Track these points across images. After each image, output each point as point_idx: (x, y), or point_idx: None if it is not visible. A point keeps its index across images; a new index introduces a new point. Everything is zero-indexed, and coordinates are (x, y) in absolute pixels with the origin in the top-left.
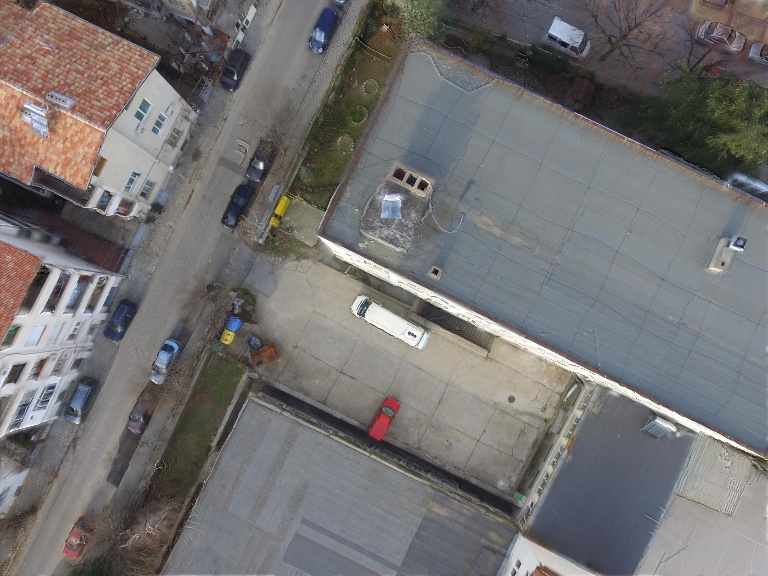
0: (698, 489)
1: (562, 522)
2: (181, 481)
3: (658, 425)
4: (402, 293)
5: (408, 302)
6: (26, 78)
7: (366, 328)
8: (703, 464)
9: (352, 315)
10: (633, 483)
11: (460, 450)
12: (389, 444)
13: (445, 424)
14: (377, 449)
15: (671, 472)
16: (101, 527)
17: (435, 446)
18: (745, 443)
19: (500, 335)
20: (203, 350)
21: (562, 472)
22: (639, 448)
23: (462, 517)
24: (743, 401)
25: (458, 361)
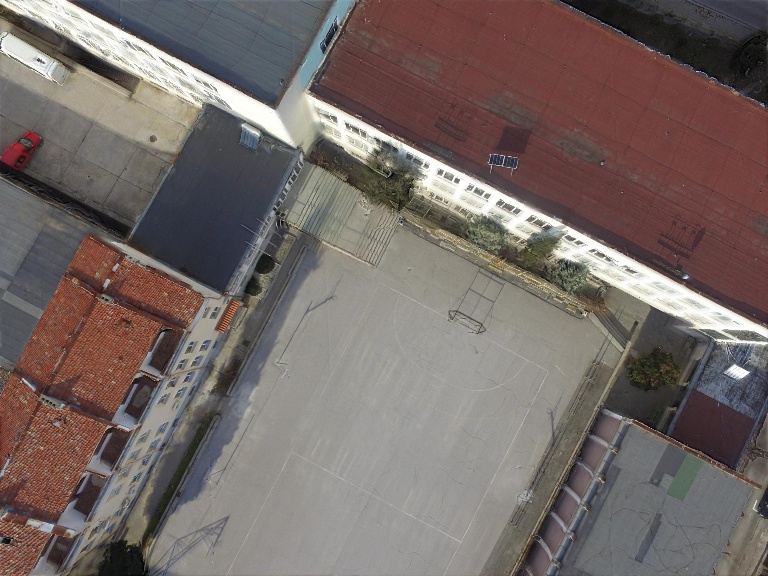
0: (336, 234)
1: (162, 230)
2: None
3: (247, 132)
4: (53, 37)
5: (57, 44)
6: None
7: (16, 68)
8: (339, 208)
9: (1, 55)
10: (231, 194)
11: (101, 186)
12: (31, 178)
13: (88, 161)
14: (11, 175)
15: (269, 185)
16: None
17: (77, 181)
18: (251, 93)
19: (132, 68)
20: None
21: (166, 184)
22: (238, 161)
23: (78, 232)
24: (257, 58)
25: (103, 102)
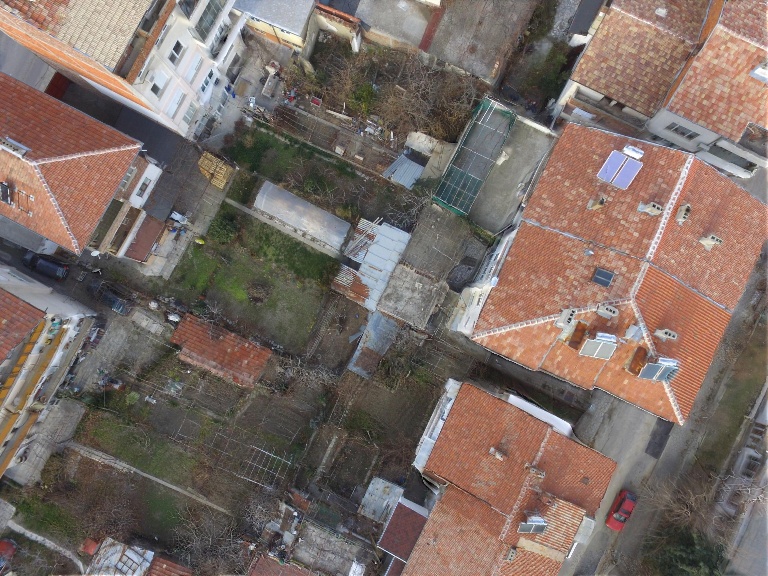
0: None
1: None
2: (714, 453)
3: None
4: None
5: None
6: (757, 33)
7: None
8: None
9: None
10: None
11: None
12: None
13: None
14: None
15: None
16: (641, 498)
17: None
18: None
19: None
20: (756, 319)
21: None
22: None
23: None
24: None
25: None
